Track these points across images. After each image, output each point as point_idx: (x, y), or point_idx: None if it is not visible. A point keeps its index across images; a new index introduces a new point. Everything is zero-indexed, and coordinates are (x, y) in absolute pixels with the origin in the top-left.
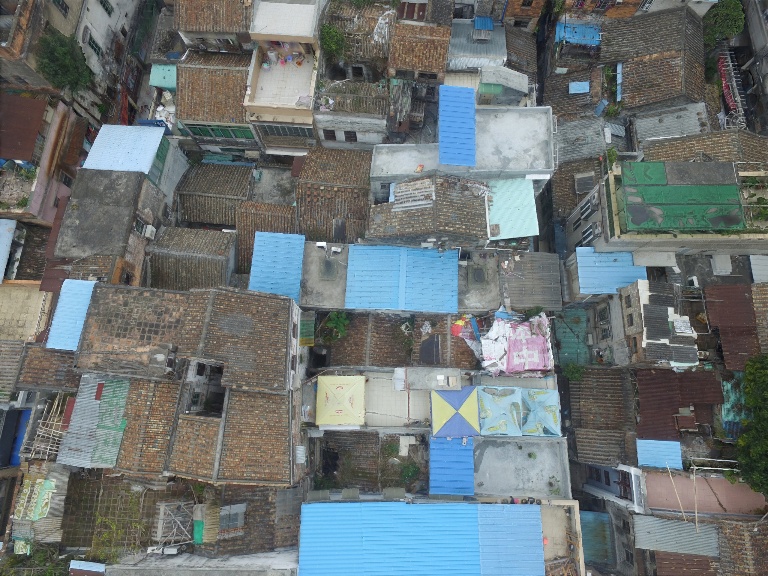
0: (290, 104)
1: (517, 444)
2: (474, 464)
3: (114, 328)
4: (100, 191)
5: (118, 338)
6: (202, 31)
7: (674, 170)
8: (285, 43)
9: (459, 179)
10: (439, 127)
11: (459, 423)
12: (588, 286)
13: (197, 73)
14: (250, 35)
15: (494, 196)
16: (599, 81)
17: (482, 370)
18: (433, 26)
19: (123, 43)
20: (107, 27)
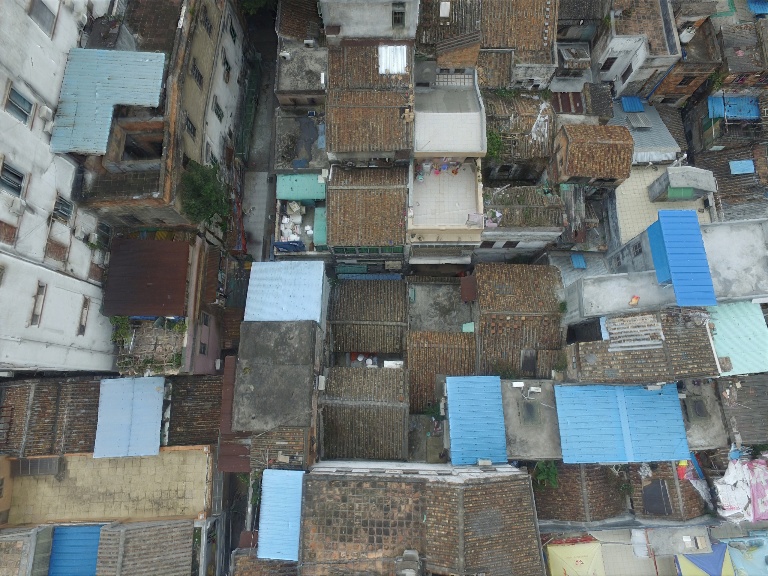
0: (454, 221)
1: None
2: None
3: (336, 530)
4: (271, 348)
5: (343, 542)
6: (357, 151)
7: None
8: (449, 157)
9: (680, 309)
10: (669, 262)
11: None
12: None
13: (349, 195)
14: (414, 154)
15: (716, 323)
16: (765, 160)
17: (723, 520)
18: (596, 120)
19: (231, 146)
20: (219, 135)
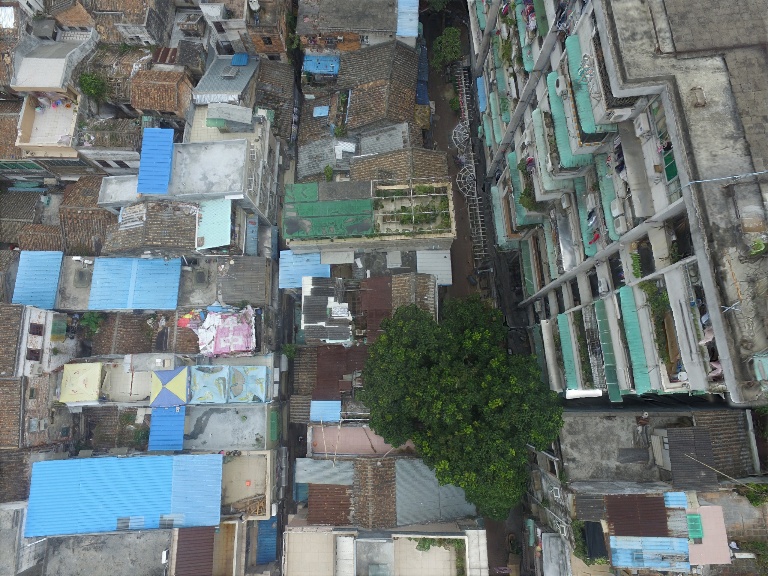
0: None
1: (236, 410)
2: (200, 427)
3: None
4: None
5: None
6: None
7: (325, 189)
8: (45, 92)
9: (171, 202)
10: None
11: (167, 395)
12: (285, 282)
13: None
14: (12, 88)
15: (203, 214)
16: (335, 105)
17: (198, 353)
18: None
19: None
20: None
